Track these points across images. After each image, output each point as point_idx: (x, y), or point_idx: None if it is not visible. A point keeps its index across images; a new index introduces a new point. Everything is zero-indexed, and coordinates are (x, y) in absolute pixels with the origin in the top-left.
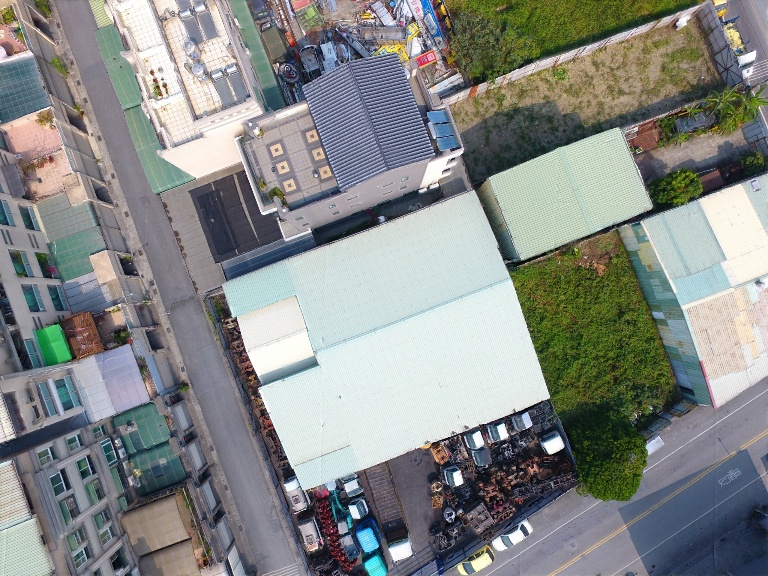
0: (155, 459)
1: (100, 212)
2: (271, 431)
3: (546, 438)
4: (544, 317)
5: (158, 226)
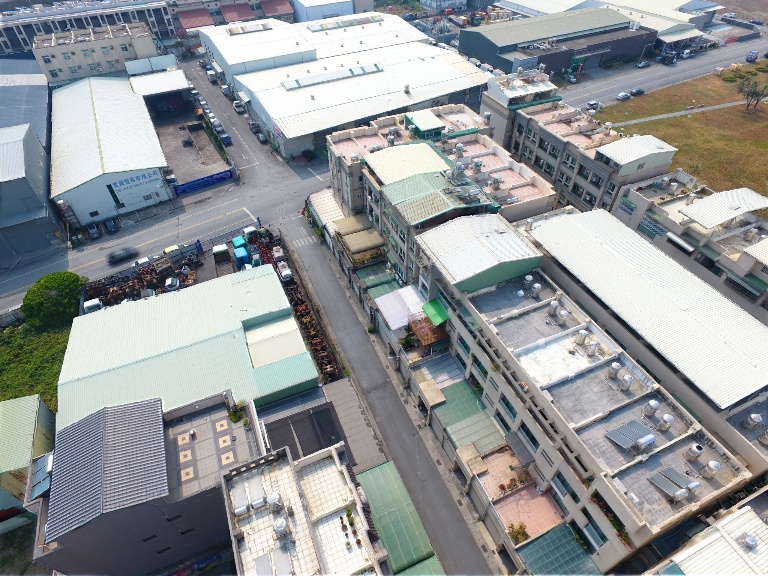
0: (377, 278)
1: (451, 448)
2: (301, 303)
3: (96, 307)
4: (56, 390)
5: (406, 453)
